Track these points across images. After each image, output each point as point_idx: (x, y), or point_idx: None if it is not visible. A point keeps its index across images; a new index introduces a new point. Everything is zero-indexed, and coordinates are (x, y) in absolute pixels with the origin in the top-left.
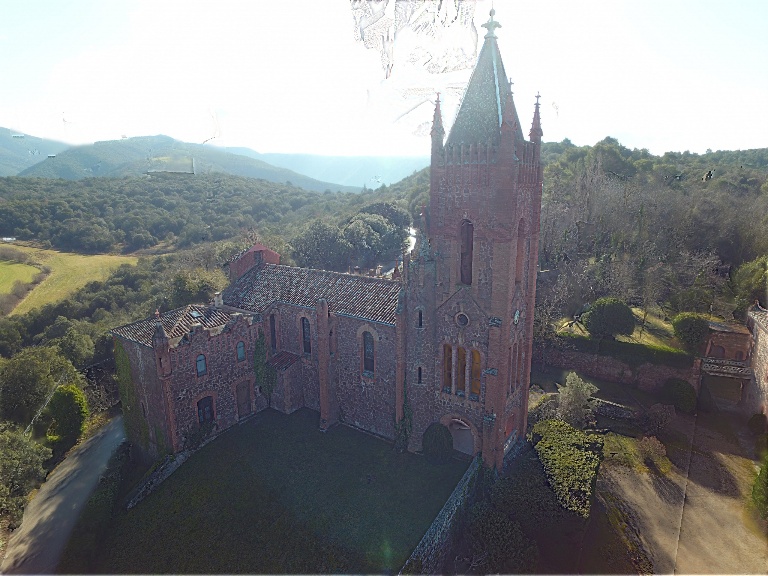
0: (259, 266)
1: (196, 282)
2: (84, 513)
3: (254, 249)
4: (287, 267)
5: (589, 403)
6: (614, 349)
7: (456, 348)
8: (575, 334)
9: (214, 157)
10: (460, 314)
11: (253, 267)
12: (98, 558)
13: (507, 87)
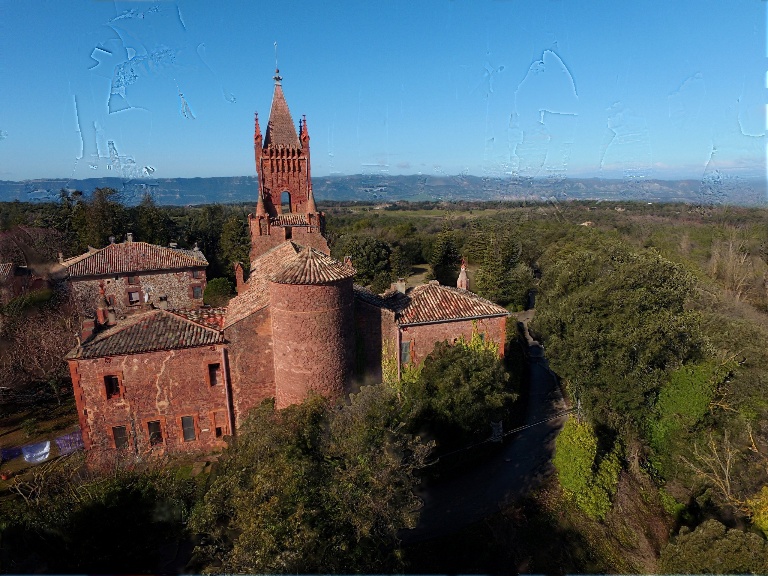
0: None
1: None
2: (517, 378)
3: None
4: None
5: None
6: None
7: None
8: None
9: None
10: None
11: None
12: None
13: None
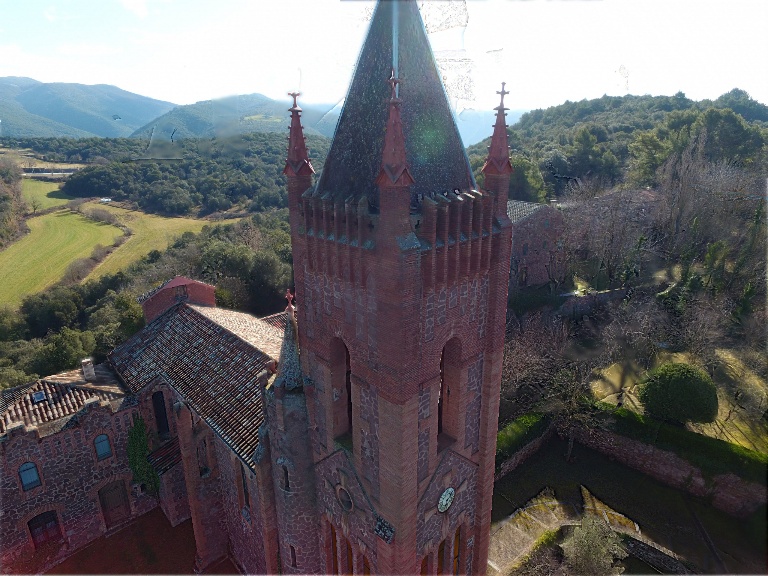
0: (178, 307)
1: (138, 307)
2: None
3: (172, 284)
4: (201, 315)
5: (609, 572)
6: (680, 443)
7: (340, 535)
8: (624, 409)
9: (226, 135)
10: (342, 488)
11: (171, 307)
12: None
13: (432, 77)
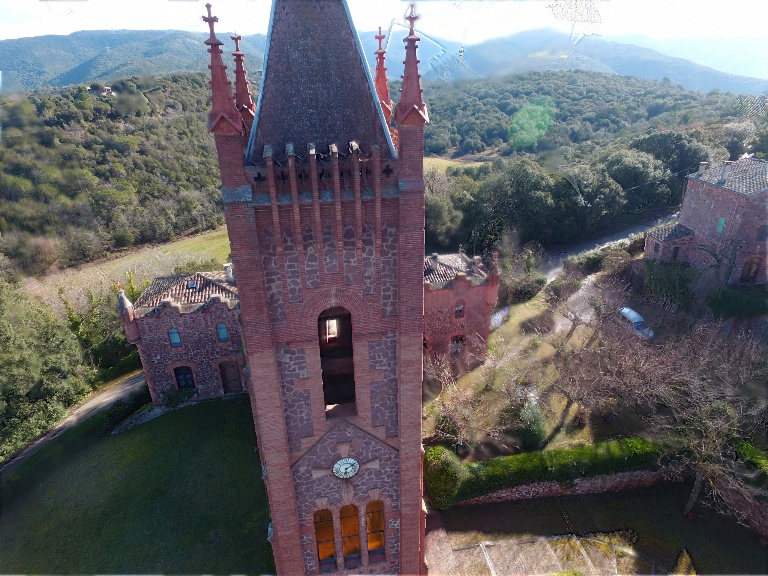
0: None
1: None
2: (80, 425)
3: None
4: None
5: None
6: None
7: None
8: None
9: None
10: None
11: None
12: (61, 465)
13: (331, 7)
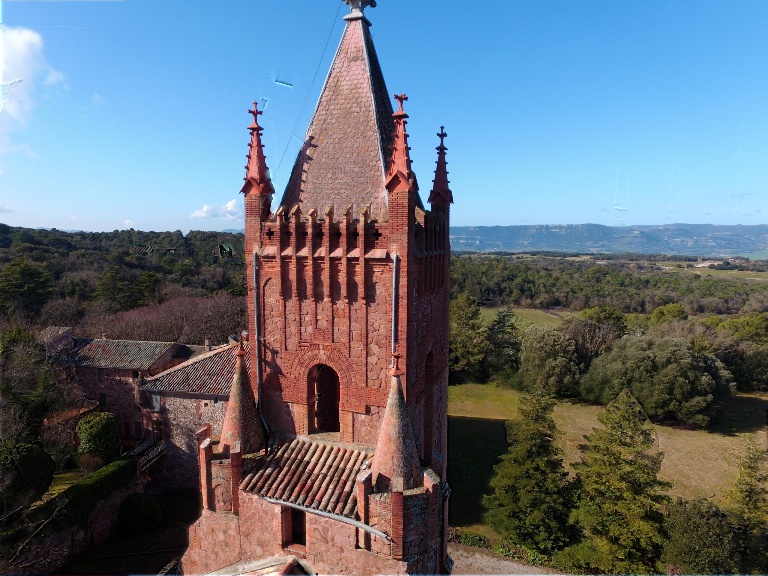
0: None
1: None
2: None
3: None
4: None
5: None
6: None
7: None
8: None
9: None
10: None
11: None
12: None
13: None
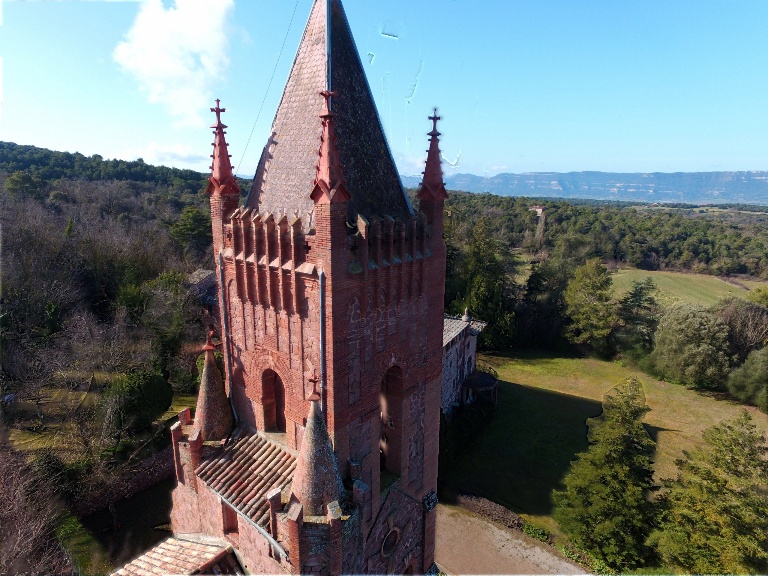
0: None
1: None
2: None
3: None
4: None
5: None
6: (169, 434)
7: None
8: None
9: None
10: None
11: None
12: None
13: None
